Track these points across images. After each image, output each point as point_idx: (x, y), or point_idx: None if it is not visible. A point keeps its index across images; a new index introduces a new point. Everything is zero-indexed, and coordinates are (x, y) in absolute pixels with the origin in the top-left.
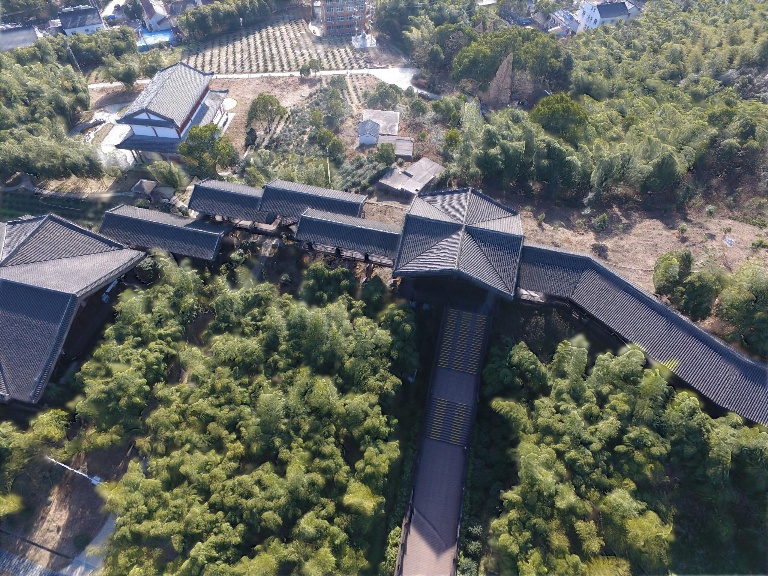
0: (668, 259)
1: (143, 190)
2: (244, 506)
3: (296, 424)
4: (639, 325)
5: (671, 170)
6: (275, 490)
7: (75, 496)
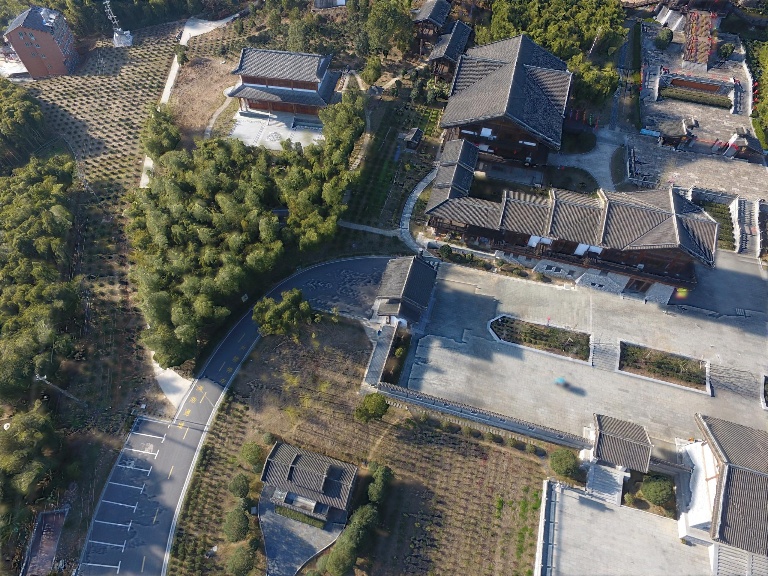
0: None
1: (382, 89)
2: (595, 4)
3: None
4: None
5: None
6: None
7: None
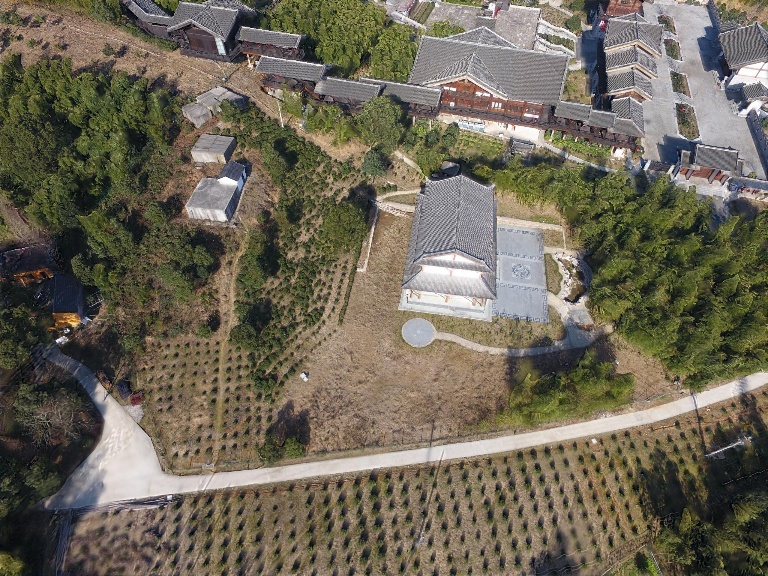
0: (108, 5)
1: None
2: None
3: None
4: (148, 5)
5: (19, 61)
6: None
7: None
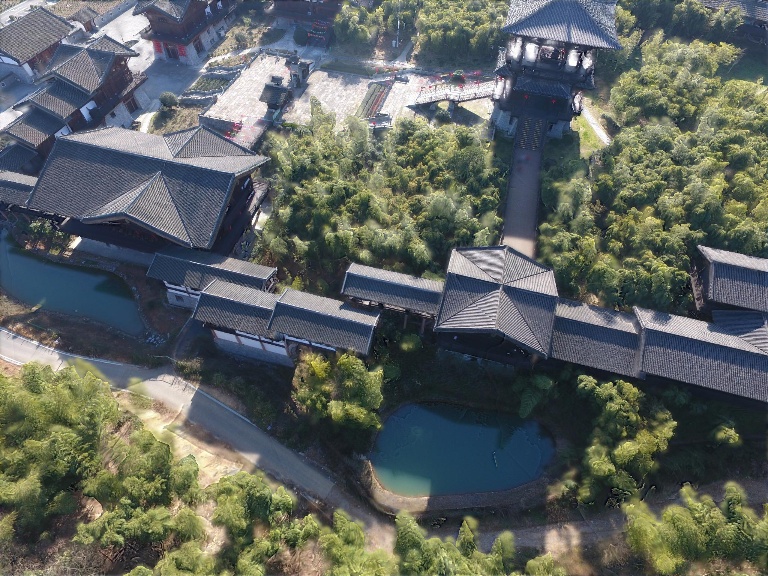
0: None
1: None
2: (473, 17)
3: (487, 2)
4: None
5: None
6: (484, 13)
7: (385, 49)
